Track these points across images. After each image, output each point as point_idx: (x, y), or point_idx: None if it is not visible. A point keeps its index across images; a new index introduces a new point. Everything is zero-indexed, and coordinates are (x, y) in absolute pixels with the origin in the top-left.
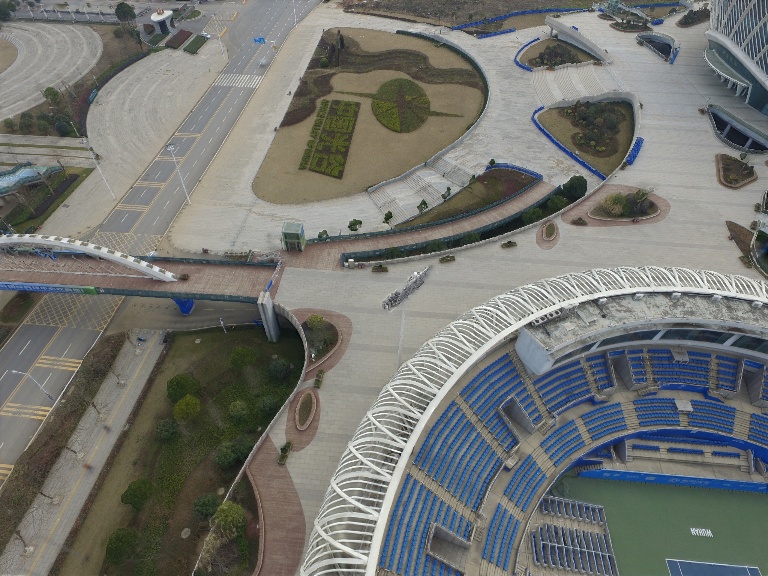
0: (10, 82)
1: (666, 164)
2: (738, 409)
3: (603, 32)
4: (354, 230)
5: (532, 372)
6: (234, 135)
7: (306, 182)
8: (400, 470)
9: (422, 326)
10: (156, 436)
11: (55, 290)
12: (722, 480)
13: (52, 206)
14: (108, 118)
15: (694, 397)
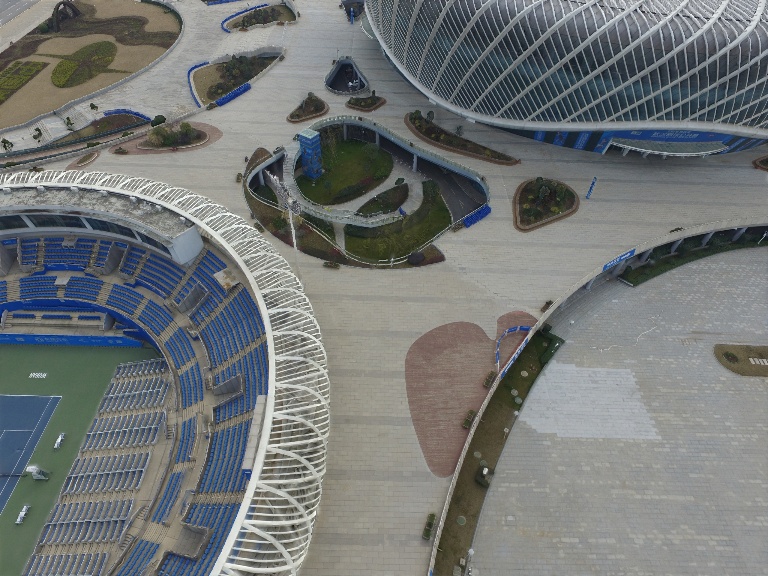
0: None
1: (254, 105)
2: (106, 282)
3: None
4: None
5: None
6: None
7: None
8: None
9: None
10: None
11: None
12: (69, 336)
13: None
14: None
15: (76, 275)
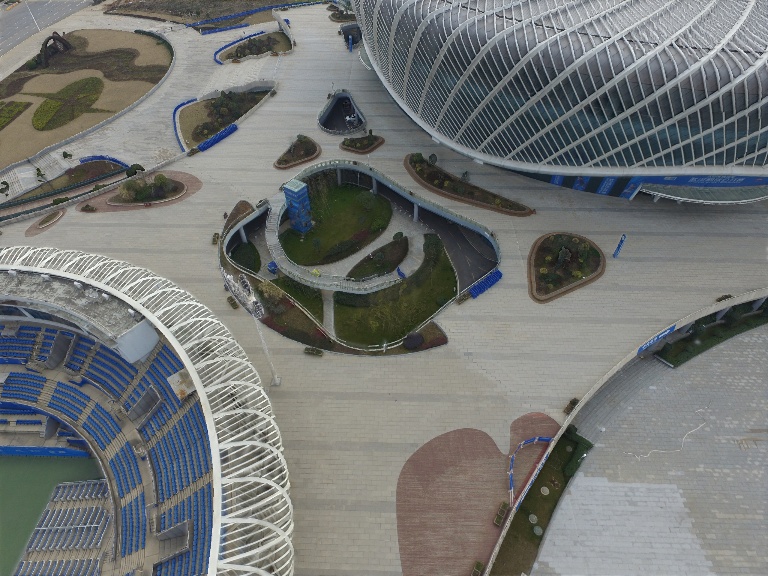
0: None
1: (240, 149)
2: (49, 378)
3: (315, 23)
4: None
5: None
6: None
7: None
8: None
9: None
10: None
11: None
12: (4, 446)
13: None
14: None
15: (17, 369)
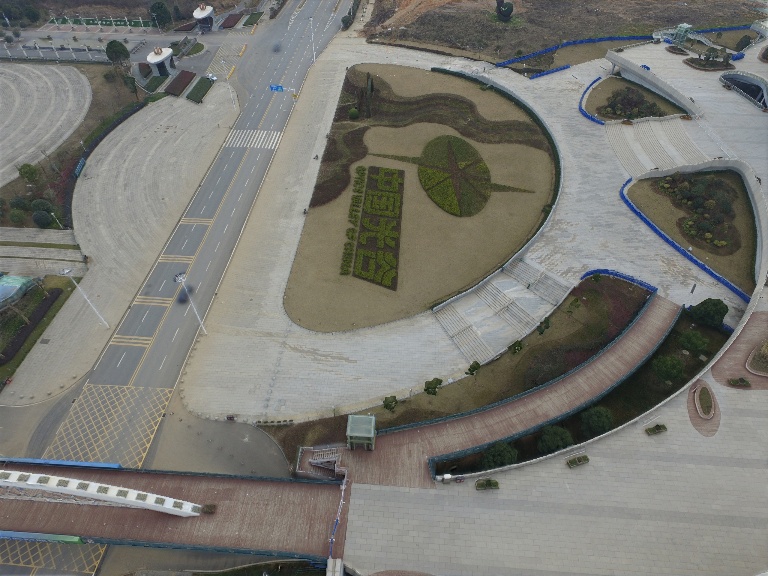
0: None
1: None
2: None
3: (678, 71)
4: (432, 394)
5: None
6: (254, 220)
7: (352, 295)
8: None
9: None
10: None
11: (22, 539)
12: None
13: (27, 342)
14: (99, 198)
15: None
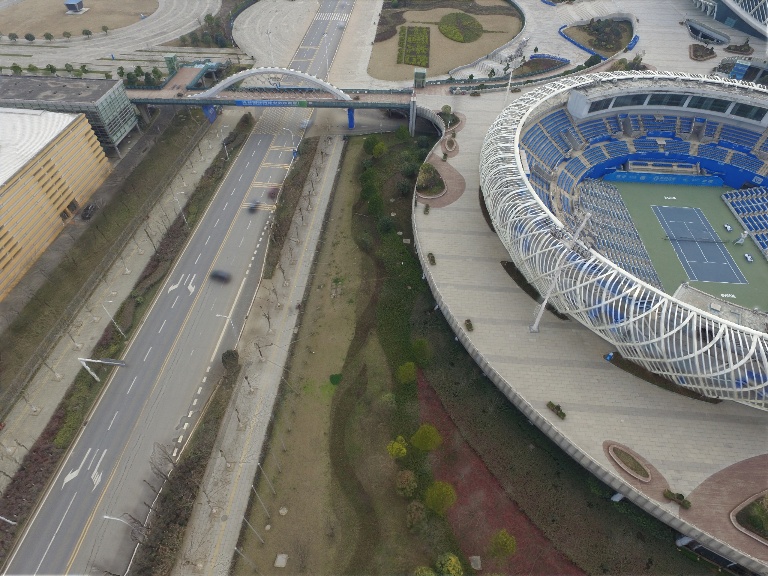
0: (164, 18)
1: (655, 50)
2: (692, 143)
3: None
4: None
5: (577, 118)
6: (343, 47)
7: (404, 70)
8: (521, 125)
9: None
10: (359, 171)
11: (281, 104)
12: (682, 175)
13: None
14: (248, 38)
15: (667, 139)
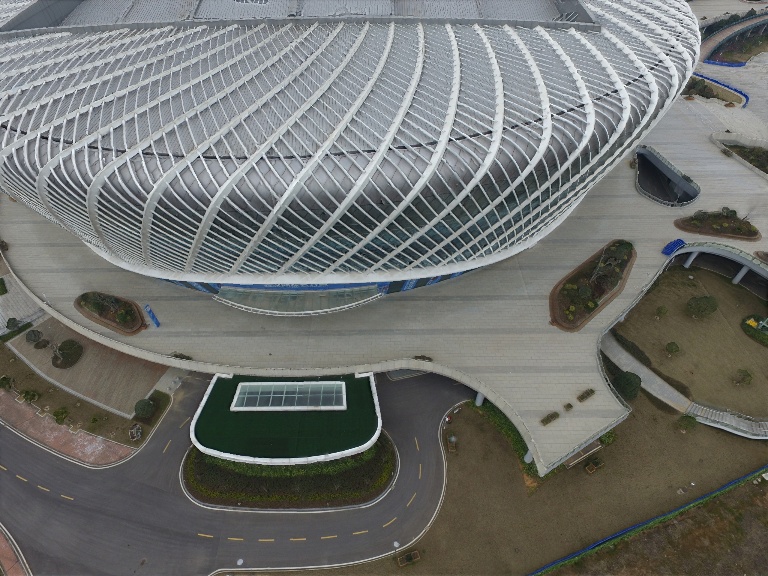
0: None
1: None
2: None
3: (759, 208)
4: None
5: None
6: None
7: None
8: None
9: (717, 3)
10: None
11: None
12: None
13: None
14: None
15: None
